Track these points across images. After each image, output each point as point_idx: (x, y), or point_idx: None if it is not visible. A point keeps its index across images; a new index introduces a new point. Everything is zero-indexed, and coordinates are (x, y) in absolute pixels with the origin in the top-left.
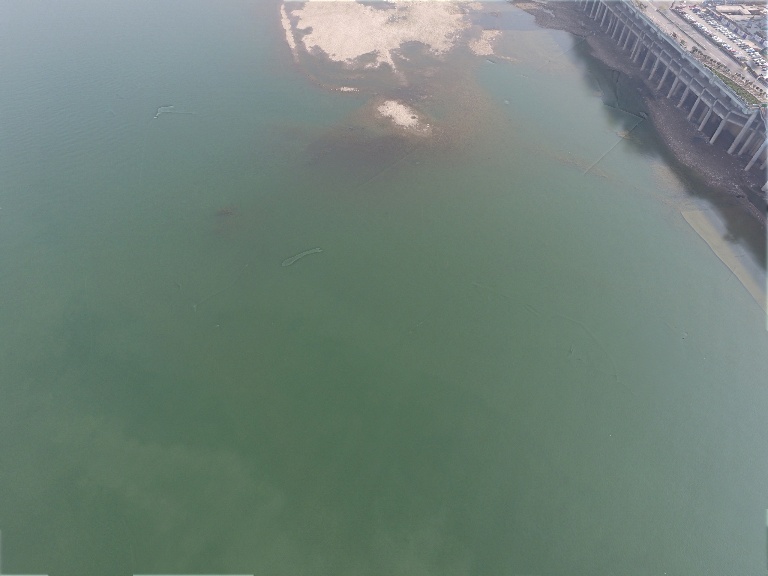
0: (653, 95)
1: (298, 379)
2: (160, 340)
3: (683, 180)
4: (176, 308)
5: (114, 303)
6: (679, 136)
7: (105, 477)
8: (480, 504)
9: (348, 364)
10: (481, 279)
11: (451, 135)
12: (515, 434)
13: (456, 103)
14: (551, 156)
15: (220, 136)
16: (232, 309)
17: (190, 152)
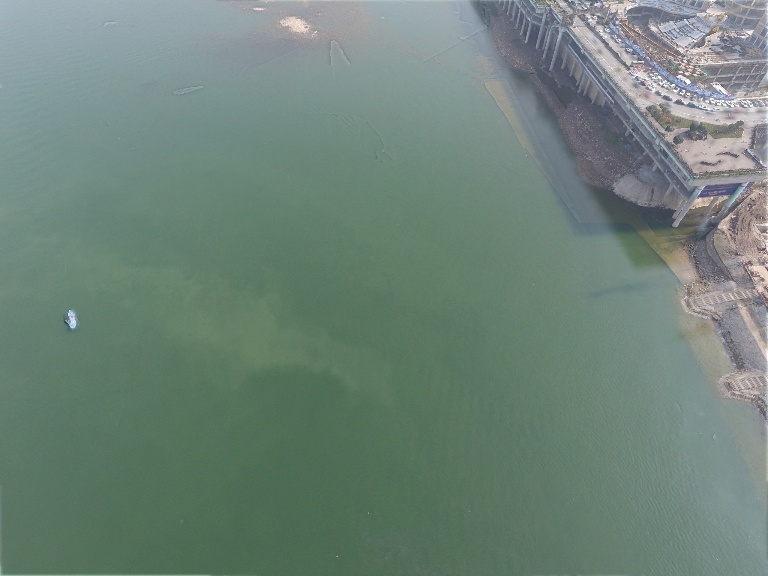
0: (498, 13)
1: (185, 172)
2: (90, 149)
3: (495, 65)
4: (105, 138)
5: (58, 129)
6: (504, 38)
7: (45, 205)
8: (290, 227)
9: (221, 164)
10: (321, 114)
11: (332, 38)
12: (323, 195)
13: (342, 18)
14: (404, 51)
15: (152, 39)
16: (146, 139)
17: (126, 47)
